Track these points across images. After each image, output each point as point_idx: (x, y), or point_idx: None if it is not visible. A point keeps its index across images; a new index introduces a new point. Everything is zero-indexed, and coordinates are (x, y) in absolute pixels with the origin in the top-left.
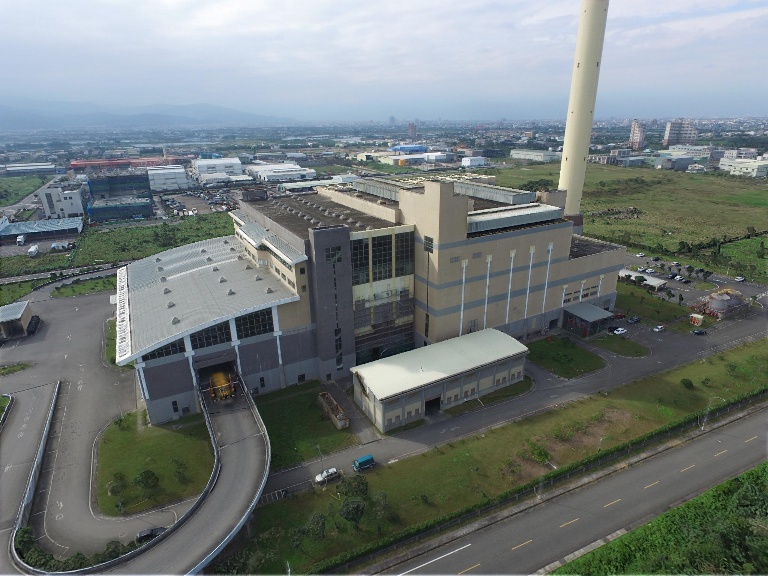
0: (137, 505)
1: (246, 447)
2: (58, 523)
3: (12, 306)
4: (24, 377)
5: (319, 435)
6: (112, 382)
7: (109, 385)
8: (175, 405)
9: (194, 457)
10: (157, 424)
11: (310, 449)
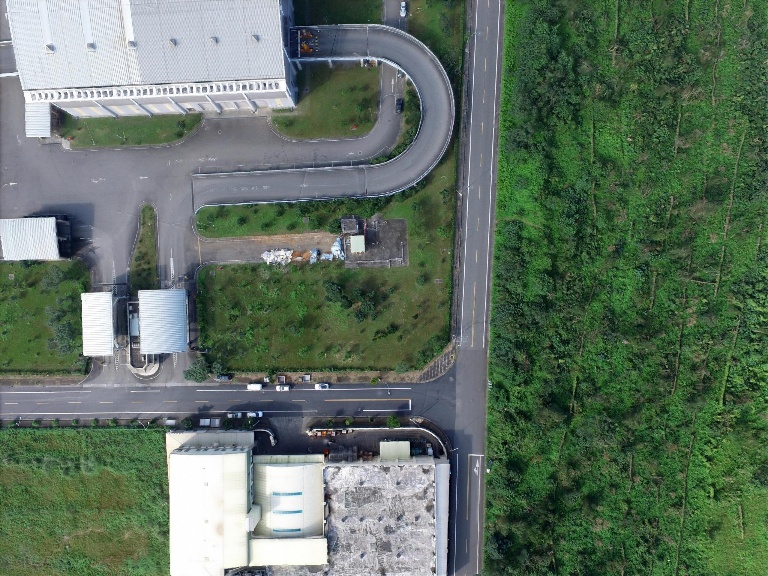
0: (372, 114)
1: (376, 40)
2: (365, 153)
3: (11, 233)
4: (168, 205)
5: (364, 2)
6: (215, 135)
7: (220, 137)
8: (292, 84)
9: (347, 81)
10: (296, 102)
11: (374, 12)
